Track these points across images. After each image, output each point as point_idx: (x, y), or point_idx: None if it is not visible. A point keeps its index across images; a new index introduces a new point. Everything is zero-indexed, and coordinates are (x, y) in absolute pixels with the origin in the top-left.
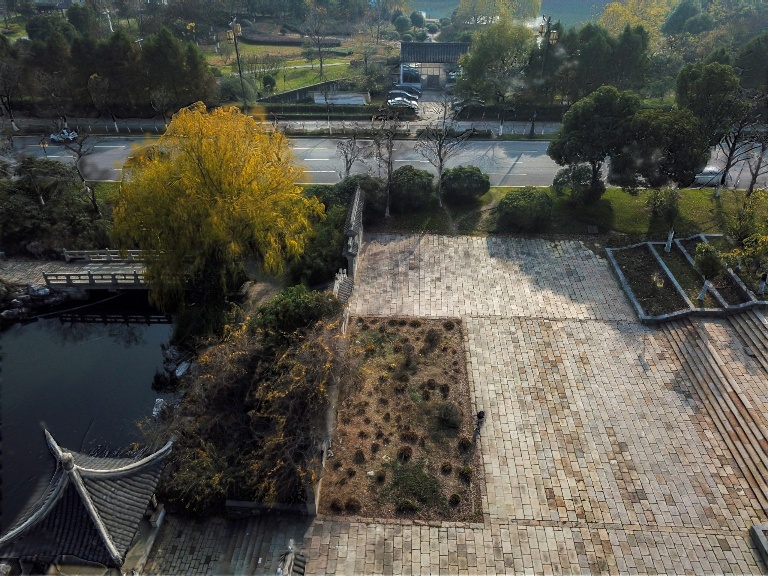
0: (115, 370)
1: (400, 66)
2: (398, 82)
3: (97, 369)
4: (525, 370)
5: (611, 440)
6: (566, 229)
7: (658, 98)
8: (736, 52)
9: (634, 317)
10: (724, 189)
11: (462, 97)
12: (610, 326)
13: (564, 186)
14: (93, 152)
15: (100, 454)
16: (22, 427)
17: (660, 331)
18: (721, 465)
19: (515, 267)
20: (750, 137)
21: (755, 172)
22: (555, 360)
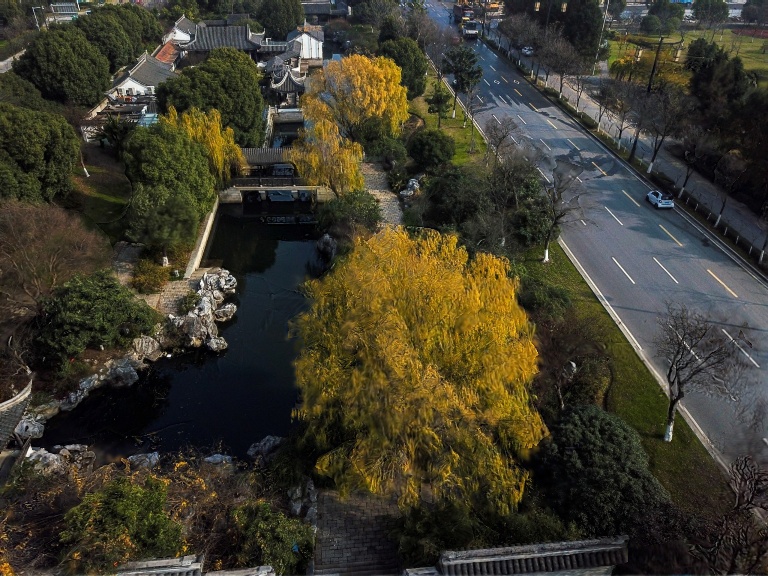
0: (266, 408)
1: None
2: None
3: (276, 395)
4: None
5: None
6: None
7: None
8: None
9: None
10: None
11: None
12: None
13: None
14: (574, 227)
15: (154, 444)
16: (216, 380)
17: None
18: None
19: None
20: None
21: None
22: None
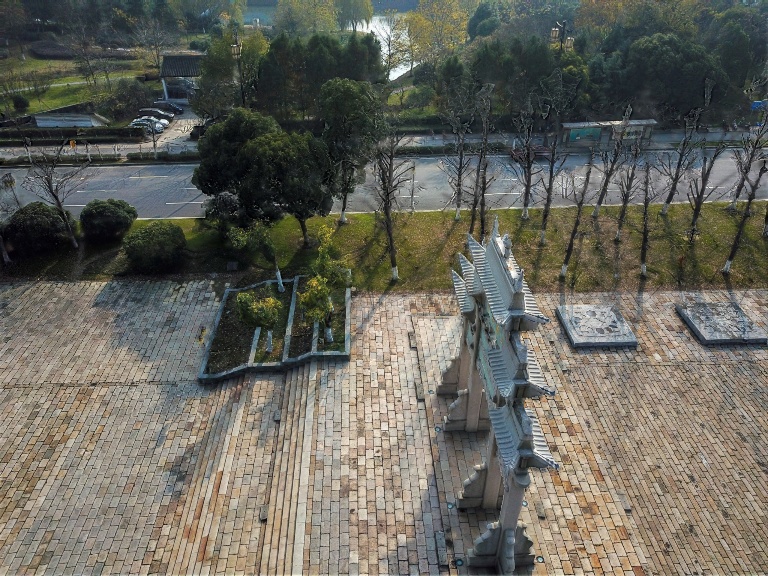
0: None
1: (161, 81)
2: (163, 98)
3: None
4: (11, 457)
5: (39, 549)
6: (204, 267)
7: (419, 108)
8: (470, 60)
9: (197, 375)
10: (402, 211)
11: (202, 114)
12: (161, 389)
13: (215, 218)
14: None
15: None
16: None
17: (213, 392)
18: (147, 574)
19: (110, 318)
20: (476, 149)
21: (385, 198)
22: (59, 440)
